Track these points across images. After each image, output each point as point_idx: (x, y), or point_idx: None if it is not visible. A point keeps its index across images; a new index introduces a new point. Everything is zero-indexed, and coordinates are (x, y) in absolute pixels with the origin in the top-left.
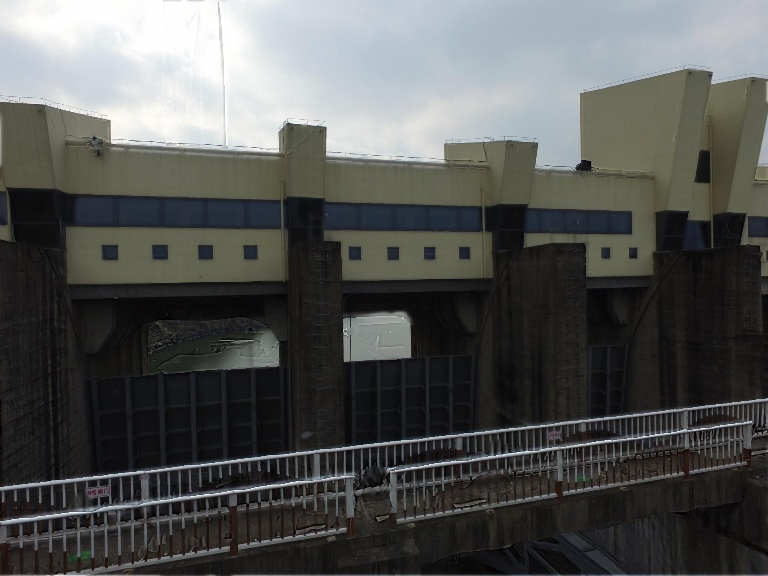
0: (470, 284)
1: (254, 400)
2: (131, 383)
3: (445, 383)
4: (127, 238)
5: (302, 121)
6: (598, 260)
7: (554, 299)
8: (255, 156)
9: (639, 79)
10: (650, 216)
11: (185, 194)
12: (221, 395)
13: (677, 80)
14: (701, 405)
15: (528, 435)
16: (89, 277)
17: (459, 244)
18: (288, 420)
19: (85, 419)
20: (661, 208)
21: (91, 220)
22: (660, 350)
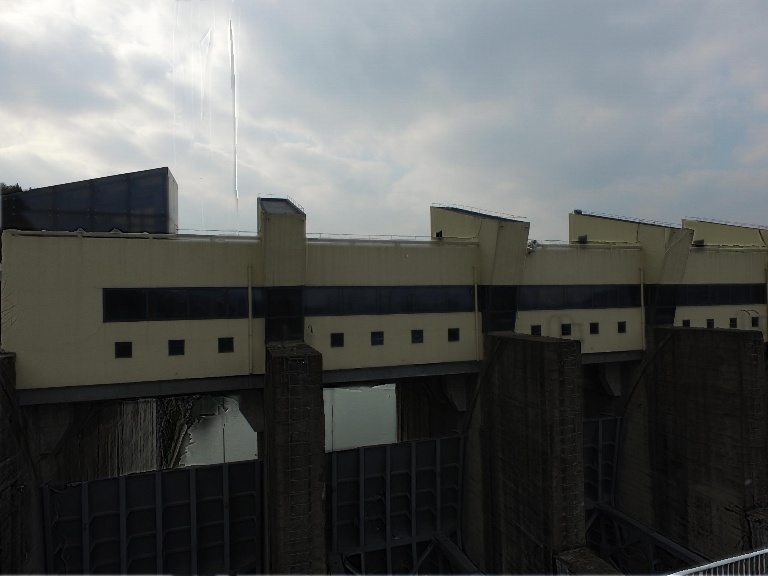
0: None
1: (601, 446)
2: None
3: None
4: (546, 319)
5: (679, 226)
6: None
7: None
8: (623, 249)
9: None
10: None
11: (581, 282)
12: None
13: None
14: None
15: None
16: None
17: (751, 315)
18: (621, 462)
19: None
20: None
21: (523, 305)
22: None
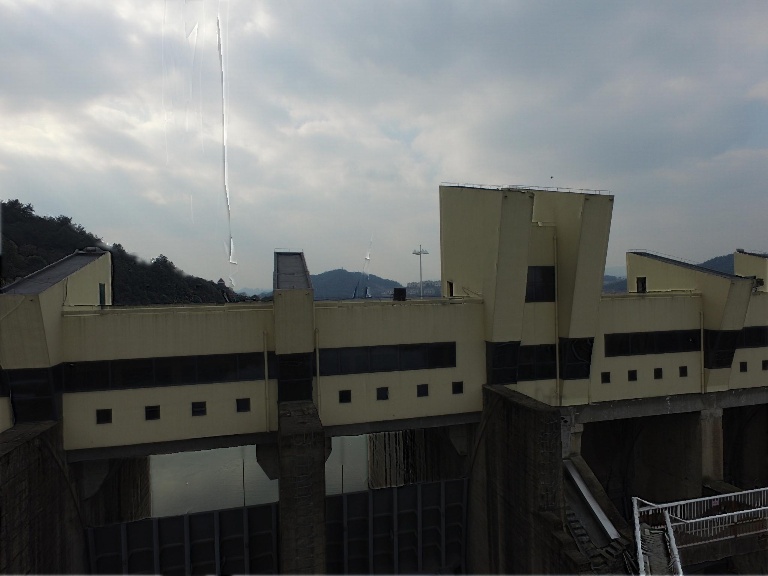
0: (252, 438)
1: None
2: None
3: None
4: None
5: None
6: (413, 399)
7: None
8: None
9: (473, 189)
10: (479, 345)
11: None
12: None
13: (496, 202)
14: (513, 575)
15: None
16: None
17: (236, 396)
18: None
19: None
20: (488, 338)
21: None
22: (487, 496)
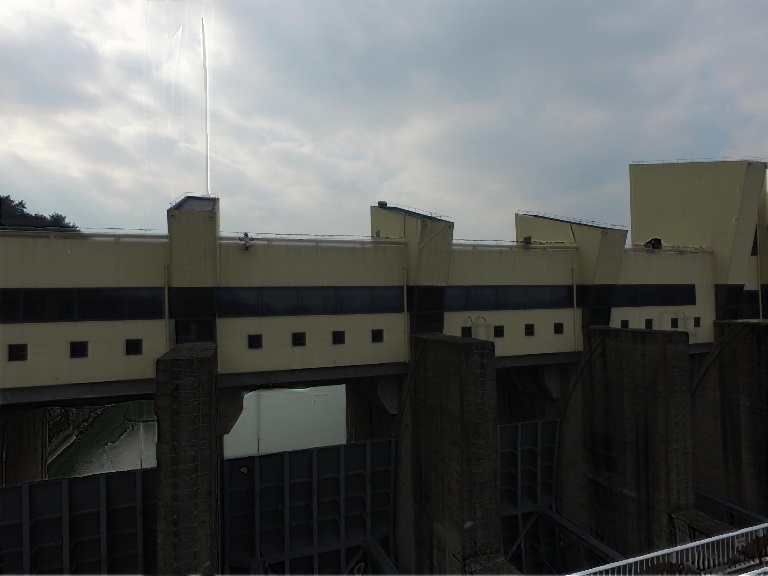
0: (563, 357)
1: (369, 472)
2: (260, 462)
3: (532, 446)
4: (270, 327)
5: (434, 218)
6: None
7: (665, 384)
8: (381, 245)
9: (695, 162)
10: (710, 288)
11: (321, 283)
12: (340, 469)
13: (737, 169)
14: (767, 466)
15: (721, 544)
16: (236, 366)
17: (554, 320)
18: (398, 490)
19: (219, 500)
20: (721, 281)
21: (238, 311)
22: (722, 412)
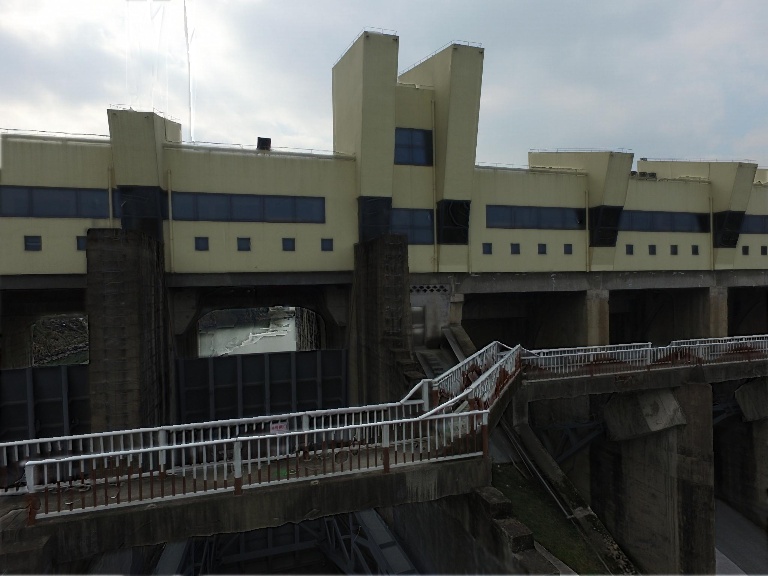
0: None
1: None
2: None
3: None
4: None
5: None
6: (278, 253)
7: None
8: None
9: None
10: (351, 203)
11: None
12: None
13: (361, 46)
14: None
15: None
16: None
17: (77, 233)
18: None
19: None
20: (358, 194)
21: None
22: (357, 355)
